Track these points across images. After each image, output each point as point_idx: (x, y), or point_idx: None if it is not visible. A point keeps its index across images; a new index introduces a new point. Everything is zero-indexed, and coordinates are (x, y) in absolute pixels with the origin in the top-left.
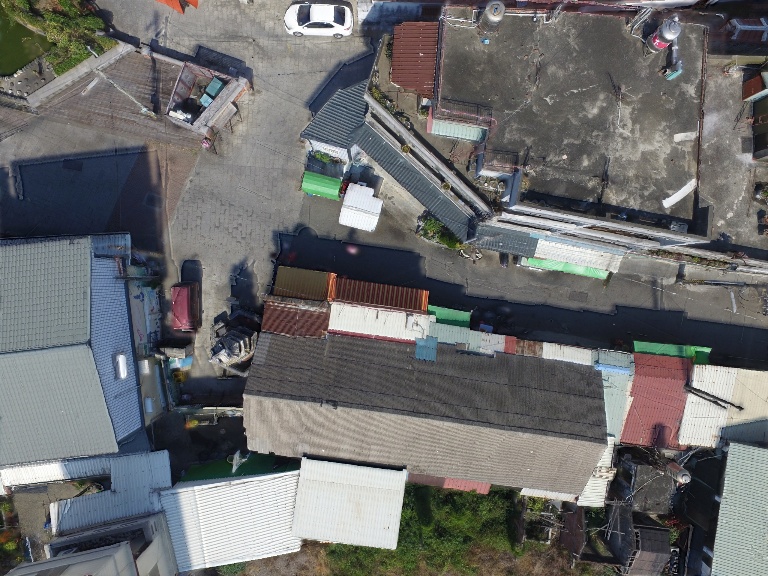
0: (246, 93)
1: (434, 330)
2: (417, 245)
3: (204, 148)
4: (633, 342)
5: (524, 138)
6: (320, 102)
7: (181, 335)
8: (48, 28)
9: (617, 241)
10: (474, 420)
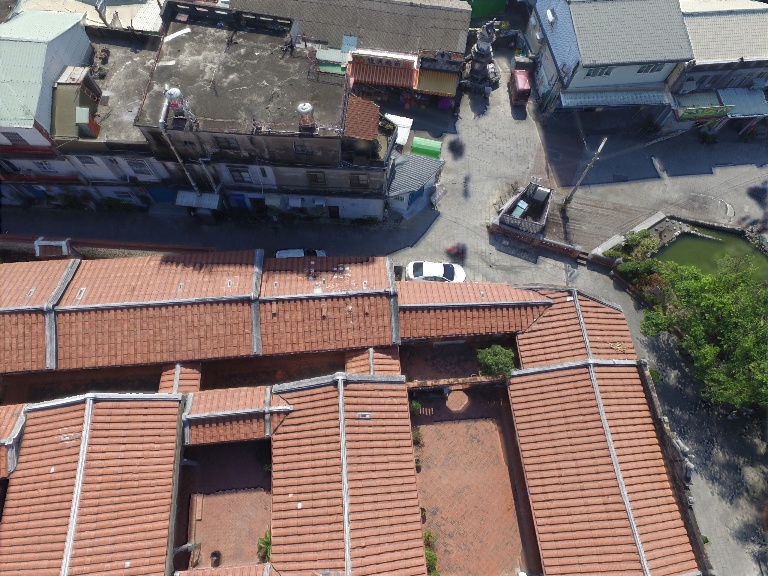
0: None
1: (343, 57)
2: None
3: None
4: None
5: (285, 64)
6: (431, 217)
7: None
8: (662, 264)
9: None
10: None
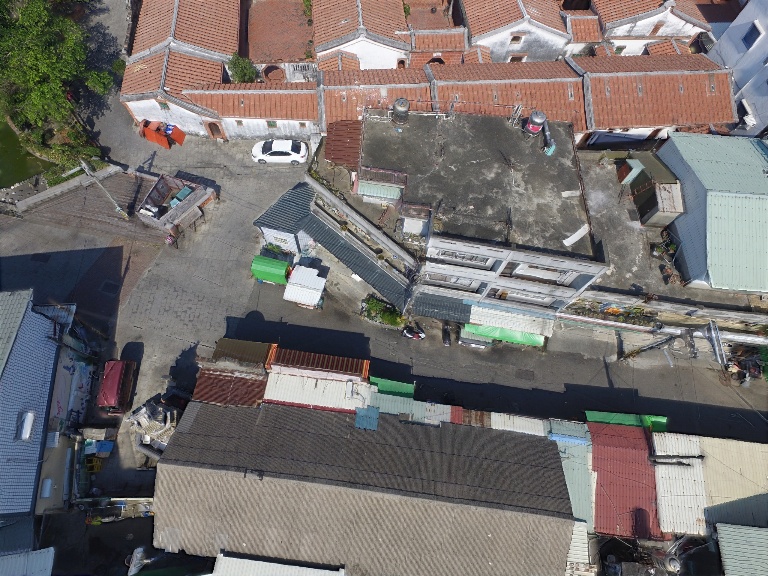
0: (212, 202)
1: (376, 400)
2: (361, 326)
3: (167, 244)
4: (584, 411)
5: (435, 194)
6: None
7: (106, 420)
8: None
9: (538, 293)
10: (419, 492)
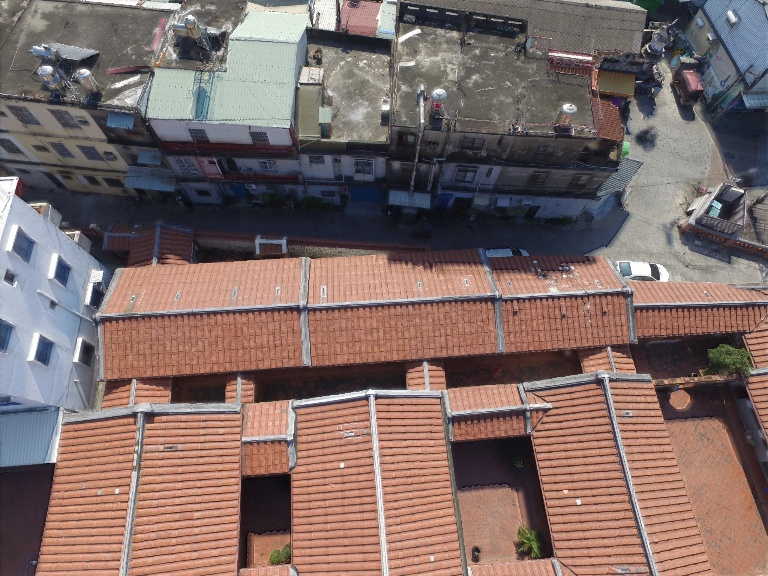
0: None
1: None
2: None
3: None
4: None
5: (522, 65)
6: (621, 217)
7: None
8: None
9: None
10: None
